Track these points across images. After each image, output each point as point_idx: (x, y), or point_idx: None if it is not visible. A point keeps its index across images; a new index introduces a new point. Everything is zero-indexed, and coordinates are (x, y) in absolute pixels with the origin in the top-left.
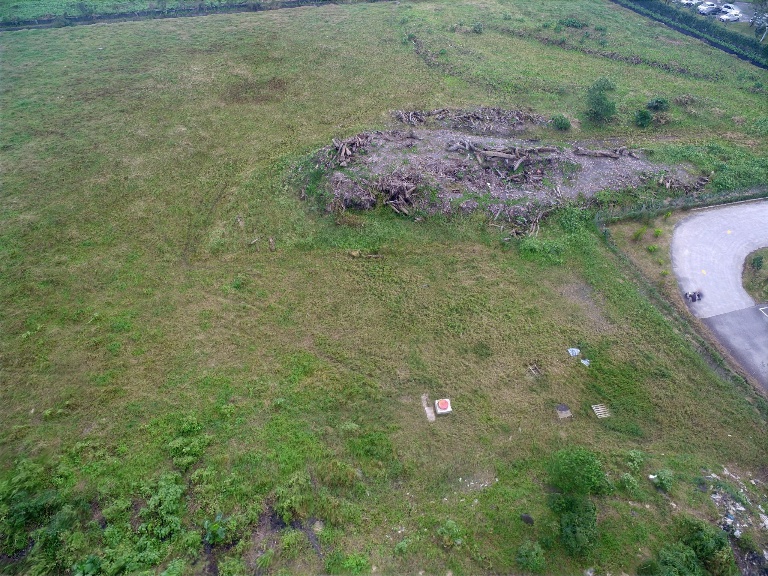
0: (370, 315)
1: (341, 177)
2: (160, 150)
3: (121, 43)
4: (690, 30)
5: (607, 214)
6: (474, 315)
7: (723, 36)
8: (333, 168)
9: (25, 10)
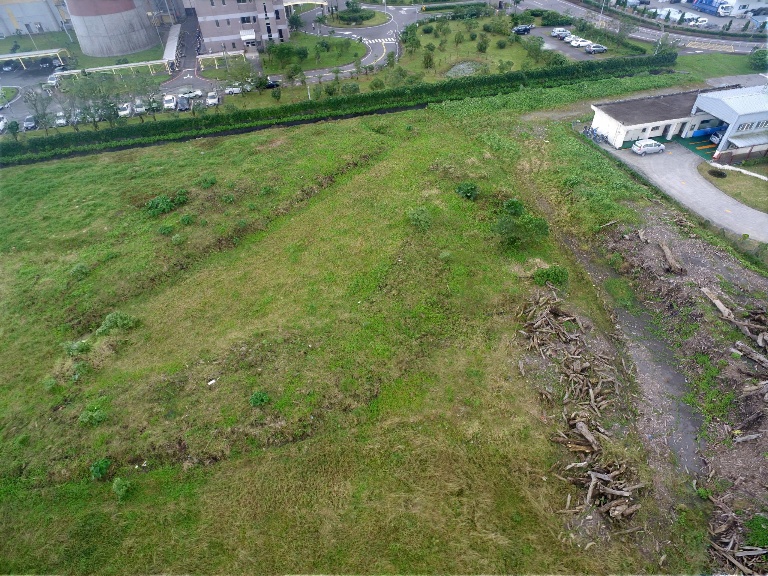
0: None
1: None
2: None
3: None
4: (235, 127)
5: None
6: None
7: (276, 114)
8: None
9: None
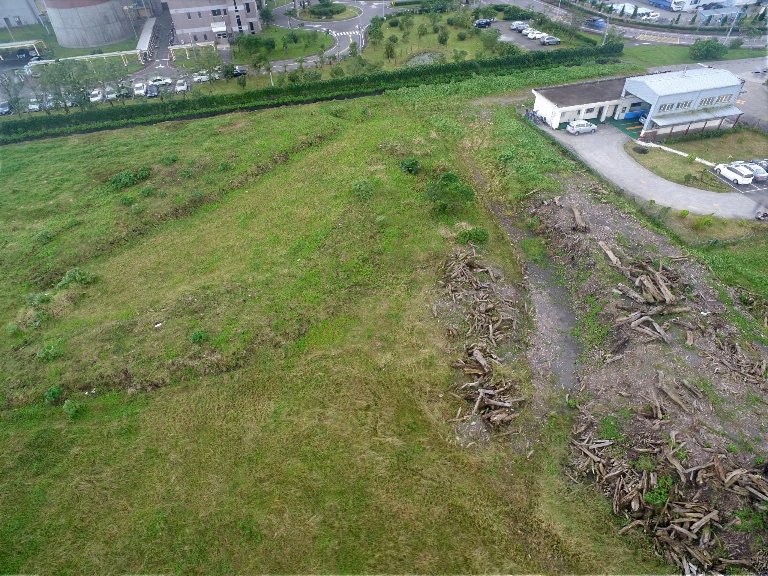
0: None
1: None
2: None
3: None
4: (201, 112)
5: None
6: None
7: (240, 99)
8: None
9: None
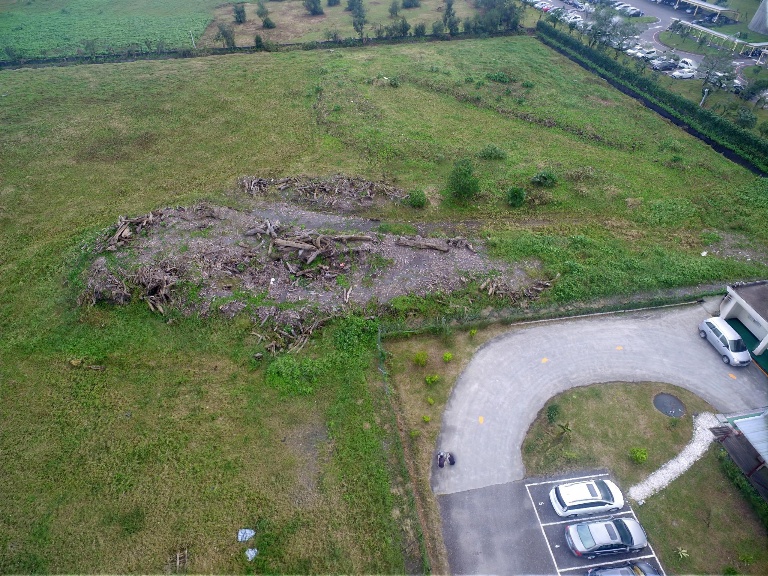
0: (33, 454)
1: (100, 264)
2: None
3: (28, 90)
4: (631, 88)
5: (402, 326)
6: (156, 464)
7: (662, 97)
8: (99, 252)
9: None
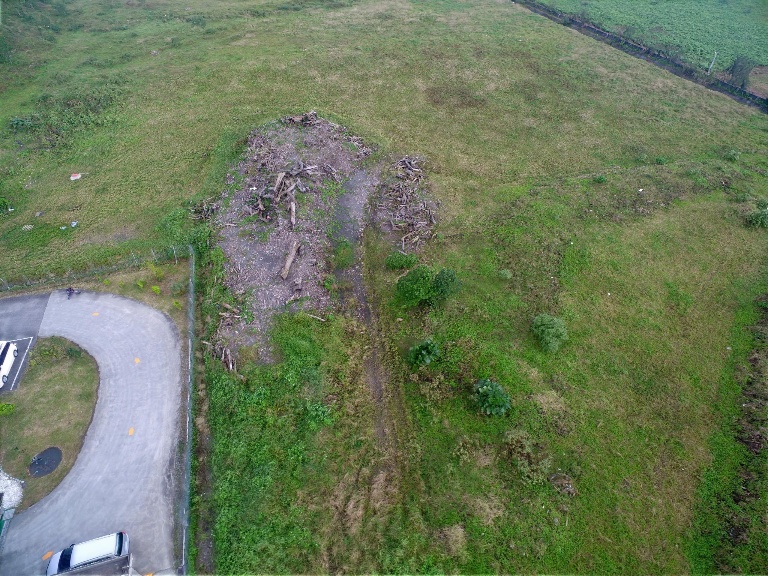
0: None
1: None
2: (351, 82)
3: (535, 43)
4: None
5: None
6: None
7: None
8: None
9: (580, 7)
